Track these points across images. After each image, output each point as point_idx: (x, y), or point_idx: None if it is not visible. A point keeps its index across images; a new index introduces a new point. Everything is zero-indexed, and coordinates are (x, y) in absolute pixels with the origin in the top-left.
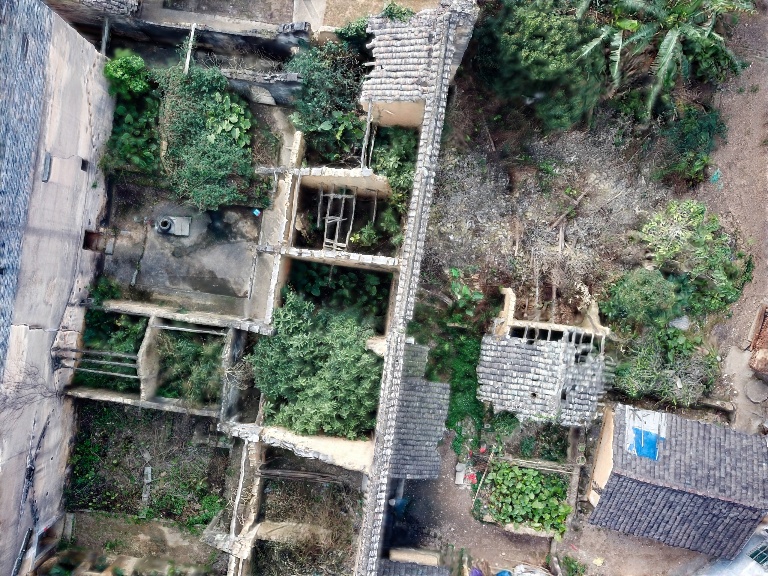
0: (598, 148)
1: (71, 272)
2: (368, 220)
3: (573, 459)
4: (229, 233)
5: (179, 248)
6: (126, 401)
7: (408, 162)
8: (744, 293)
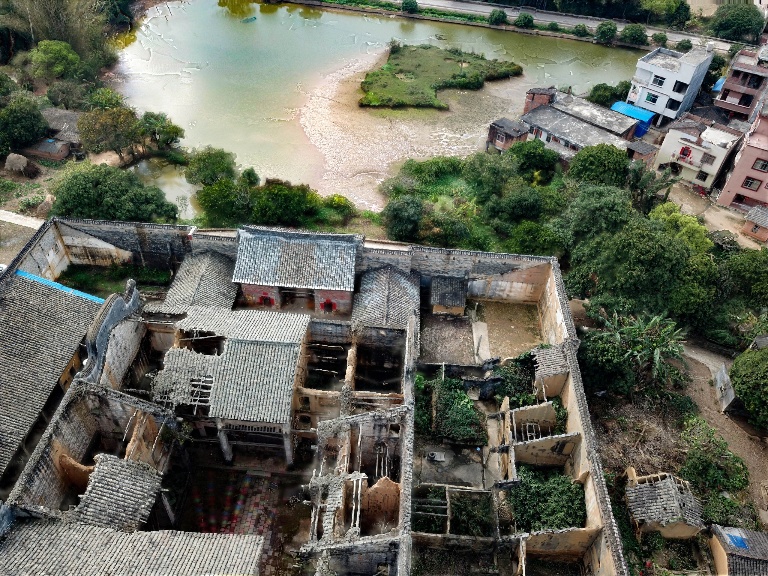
0: (641, 411)
1: None
2: (547, 435)
3: (702, 562)
4: (466, 459)
5: (440, 468)
6: (438, 535)
7: None
8: (749, 481)
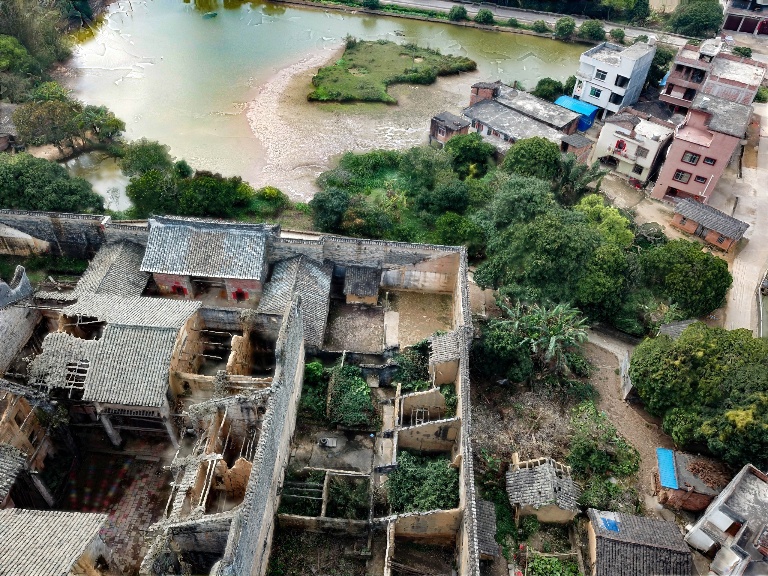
0: (539, 398)
1: (286, 449)
2: None
3: (575, 545)
4: (358, 445)
5: (331, 453)
6: (312, 518)
7: (452, 394)
8: (640, 467)
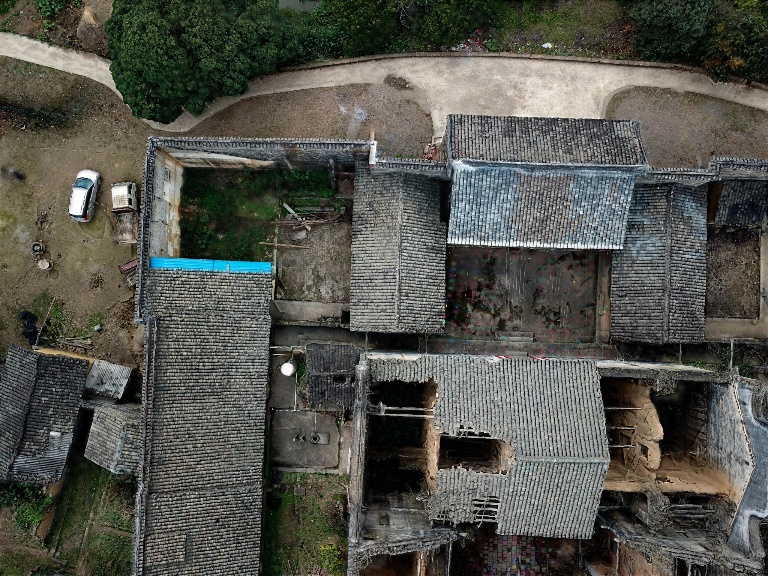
0: None
1: None
2: None
3: None
4: None
5: None
6: None
7: None
8: None
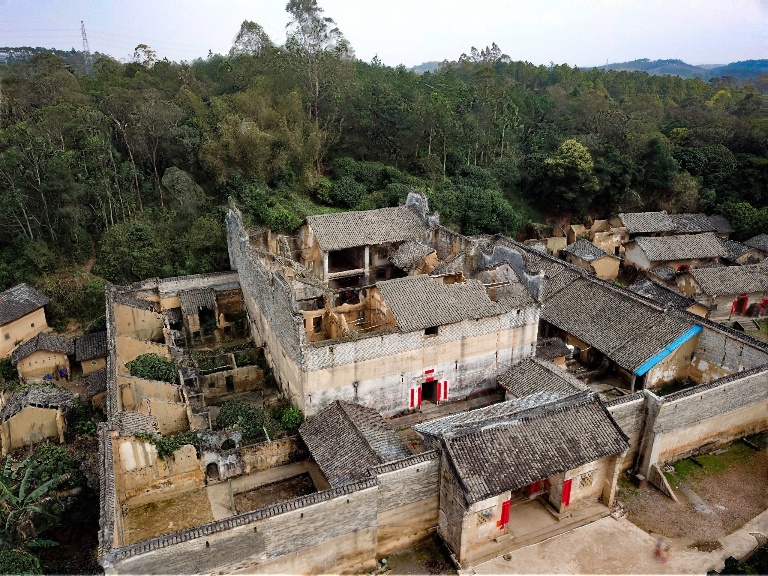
0: None
1: None
2: None
3: None
4: None
5: None
6: None
7: None
8: None
